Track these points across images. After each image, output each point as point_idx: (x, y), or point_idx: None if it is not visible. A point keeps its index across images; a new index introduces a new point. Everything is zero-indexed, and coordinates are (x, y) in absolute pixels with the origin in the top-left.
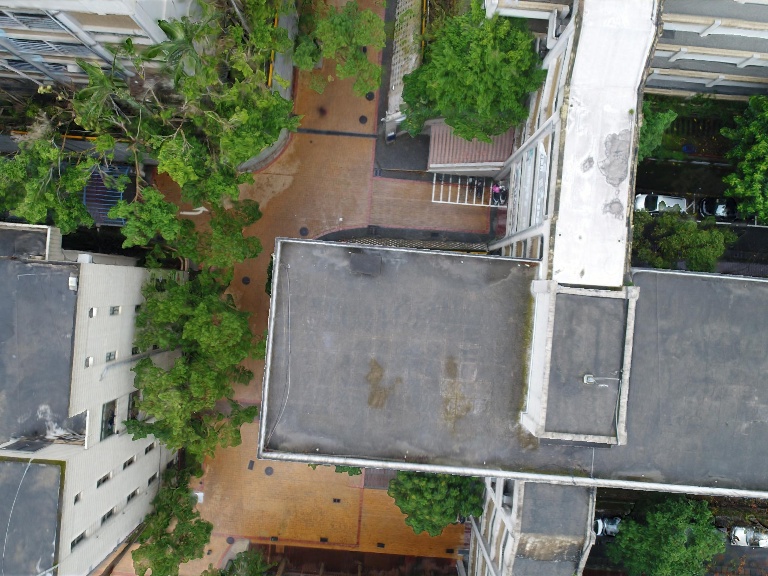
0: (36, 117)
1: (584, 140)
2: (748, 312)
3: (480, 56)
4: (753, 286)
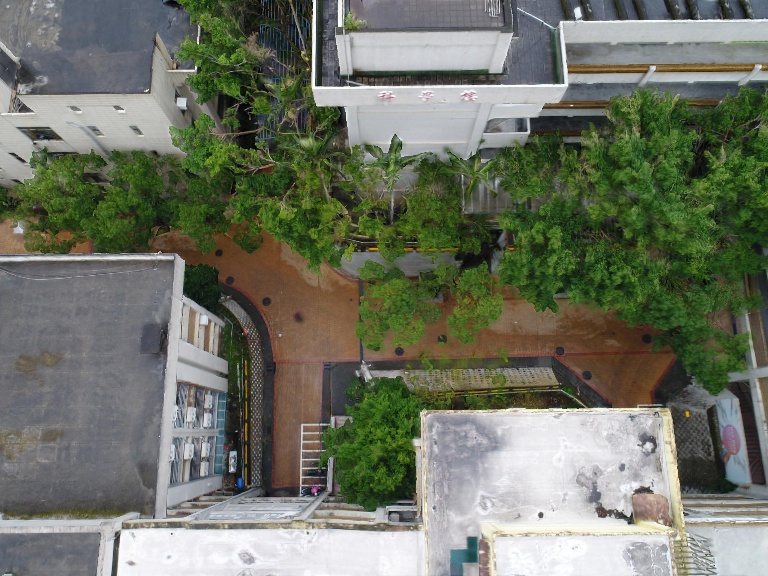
0: None
1: (272, 551)
2: None
3: (380, 438)
4: None
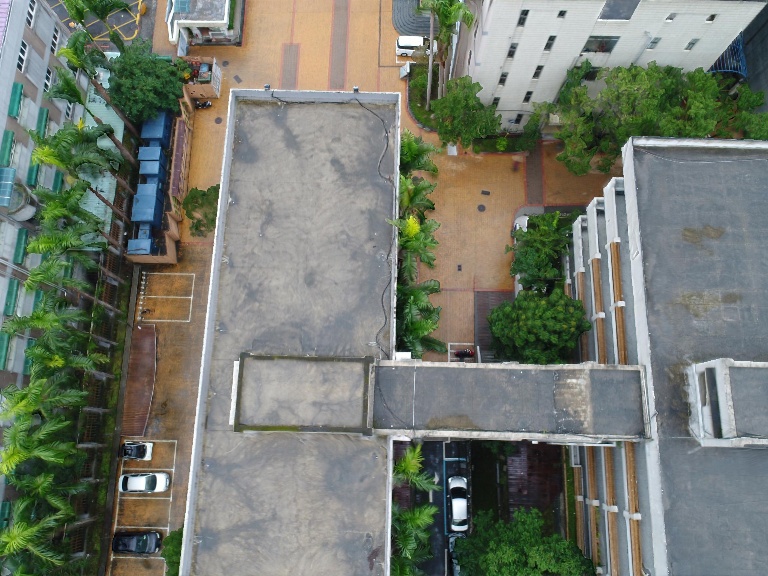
0: None
1: None
2: None
3: None
4: None
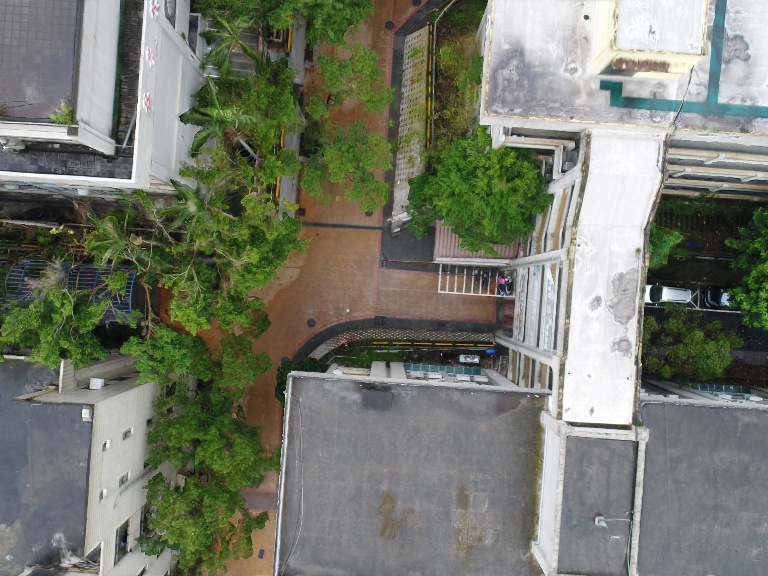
0: (49, 263)
1: (592, 279)
2: (756, 439)
3: (487, 184)
4: (761, 413)
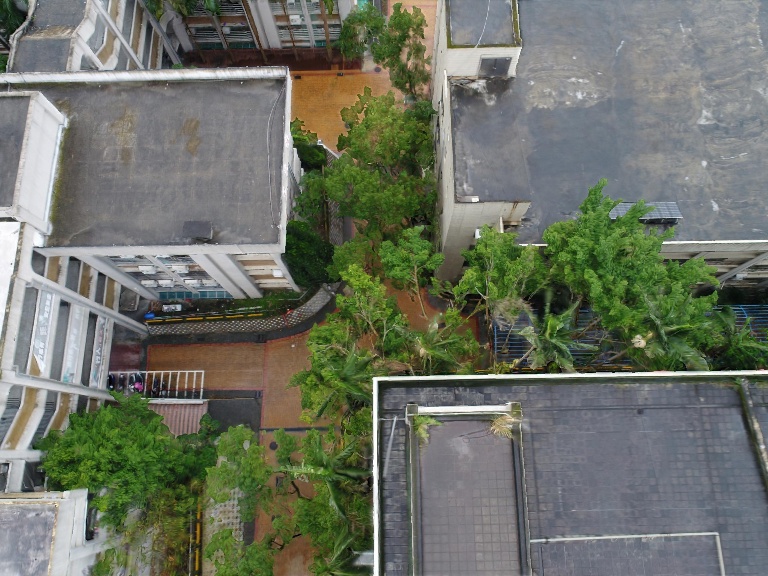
0: None
1: None
2: None
3: None
4: None
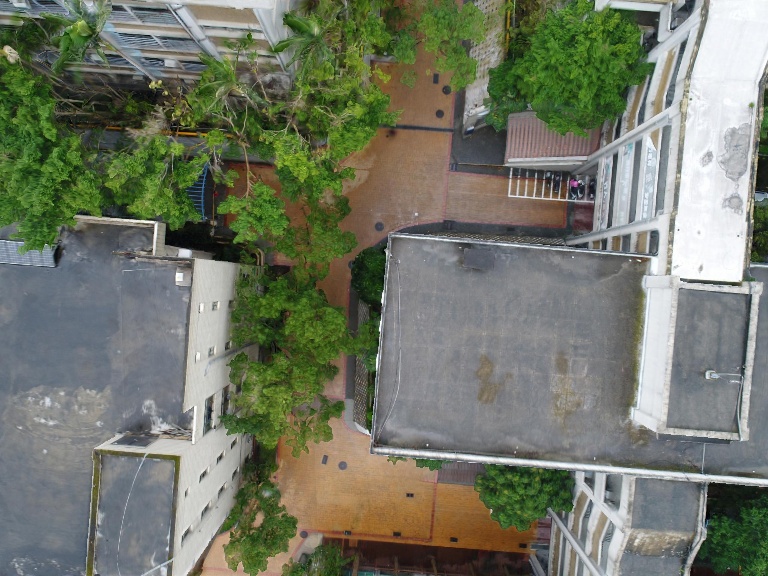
0: (152, 112)
1: (703, 134)
2: None
3: (587, 49)
4: None
